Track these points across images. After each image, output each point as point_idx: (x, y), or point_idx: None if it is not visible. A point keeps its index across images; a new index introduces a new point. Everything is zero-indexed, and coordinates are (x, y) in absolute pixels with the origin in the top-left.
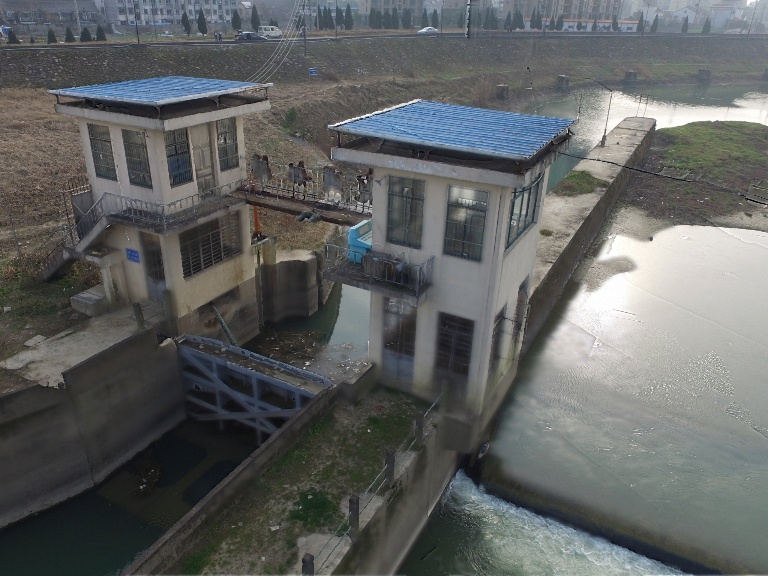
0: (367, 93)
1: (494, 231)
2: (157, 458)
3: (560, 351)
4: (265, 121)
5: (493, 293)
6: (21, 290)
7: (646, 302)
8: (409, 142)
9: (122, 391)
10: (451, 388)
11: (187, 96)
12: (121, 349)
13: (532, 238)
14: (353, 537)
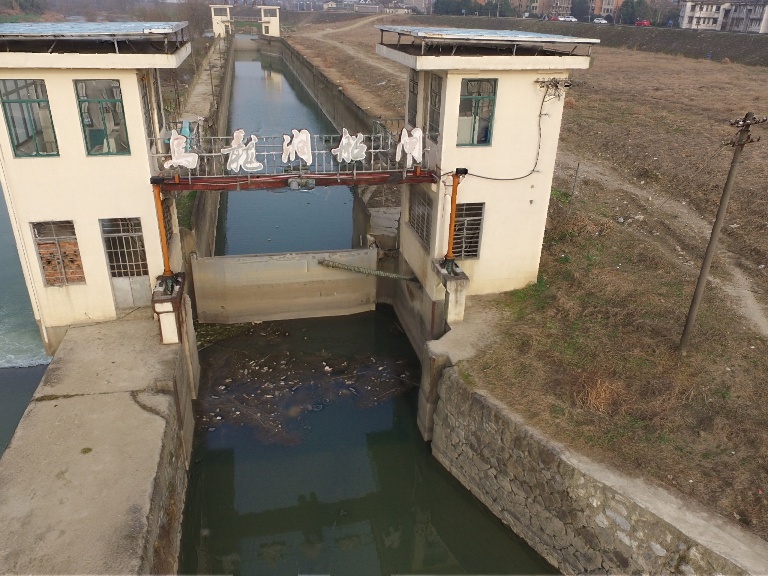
0: None
1: None
2: None
3: None
4: None
5: None
6: None
7: None
8: None
9: None
10: None
11: (387, 26)
12: None
13: None
14: None
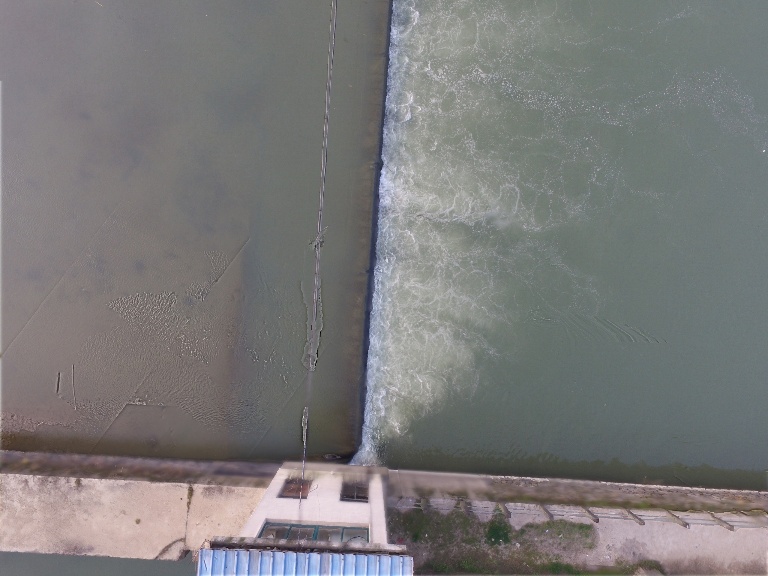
0: None
1: None
2: None
3: (166, 431)
4: None
5: None
6: None
7: (23, 365)
8: None
9: None
10: None
11: None
12: None
13: None
14: None
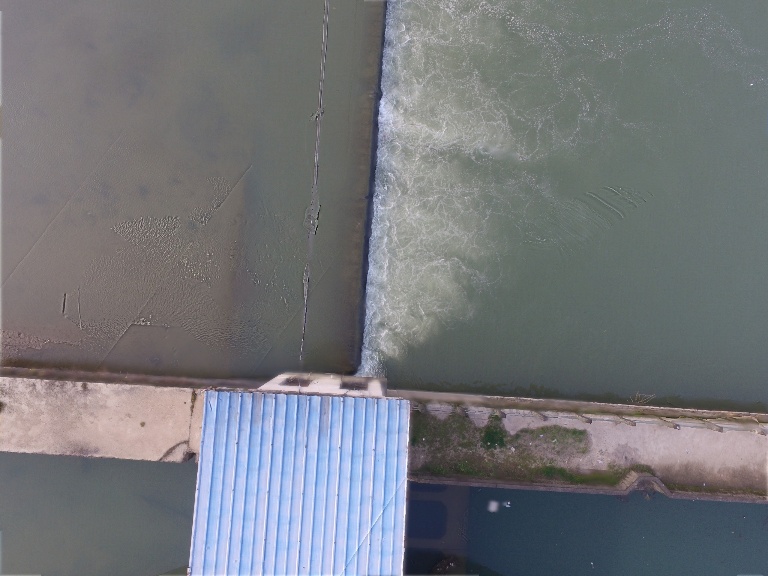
0: None
1: None
2: (428, 575)
3: (170, 351)
4: None
5: None
6: None
7: (30, 286)
8: None
9: None
10: None
11: None
12: None
13: None
14: None
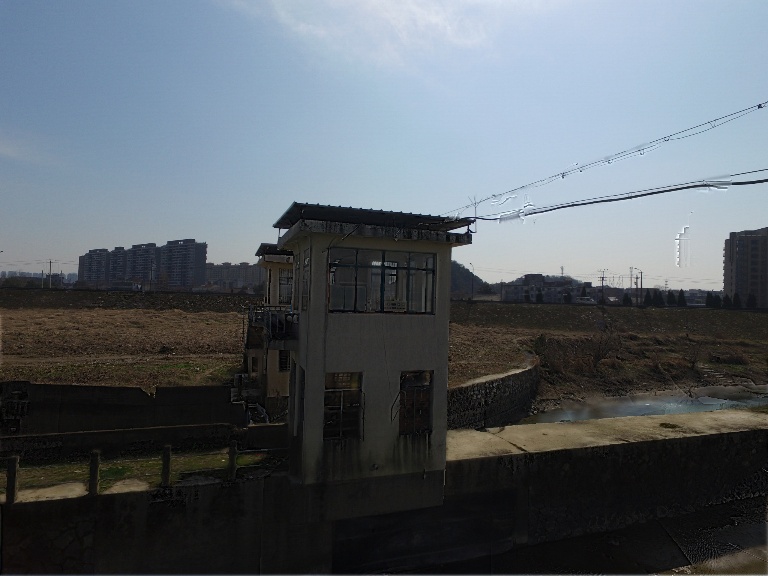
0: (609, 326)
1: (308, 279)
2: None
3: (613, 554)
4: (515, 342)
5: (309, 340)
6: (228, 371)
7: None
8: (281, 219)
9: (192, 420)
10: (299, 448)
11: None
12: (200, 390)
13: (425, 327)
14: (88, 493)
